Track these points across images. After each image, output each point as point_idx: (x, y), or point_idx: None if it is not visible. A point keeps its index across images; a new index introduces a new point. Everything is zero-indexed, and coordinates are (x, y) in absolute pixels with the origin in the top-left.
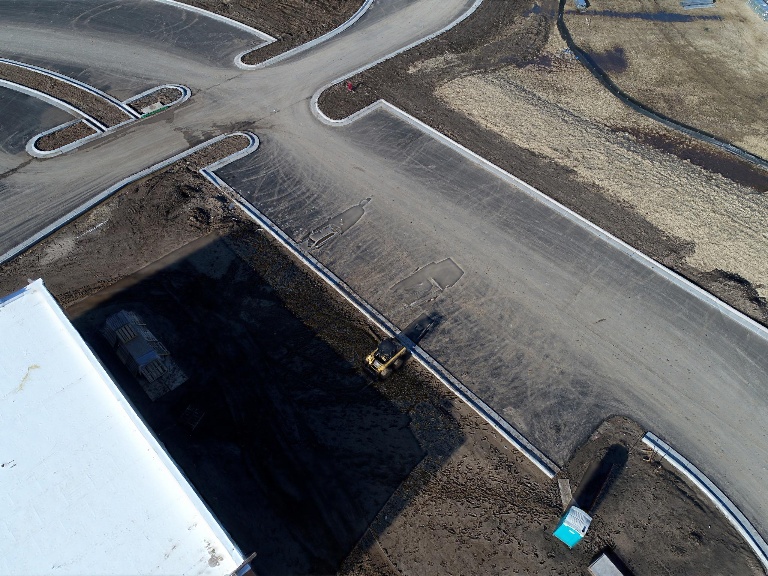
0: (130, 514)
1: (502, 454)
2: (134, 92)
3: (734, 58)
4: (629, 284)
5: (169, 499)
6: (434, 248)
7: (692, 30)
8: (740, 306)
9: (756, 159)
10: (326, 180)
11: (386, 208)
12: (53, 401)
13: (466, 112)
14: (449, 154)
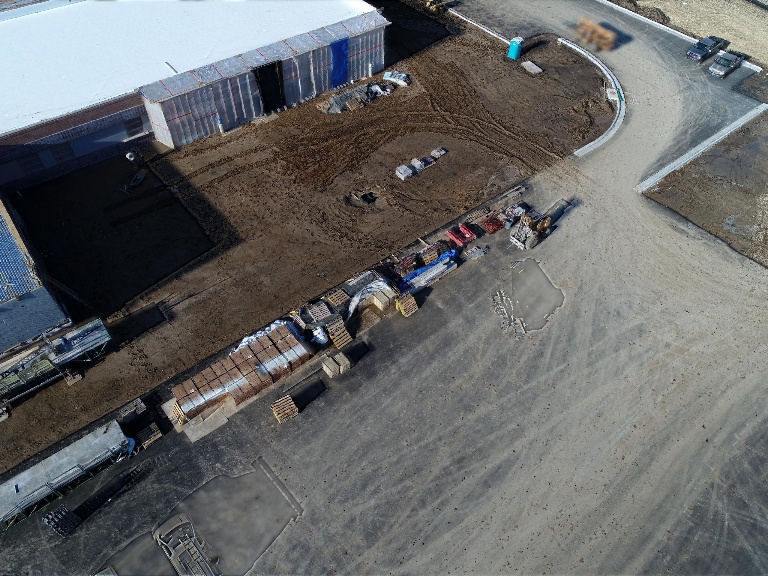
0: (331, 5)
1: (488, 38)
2: None
3: None
4: None
5: (346, 3)
6: None
7: None
8: (624, 6)
9: None
10: None
11: None
12: None
13: None
14: None
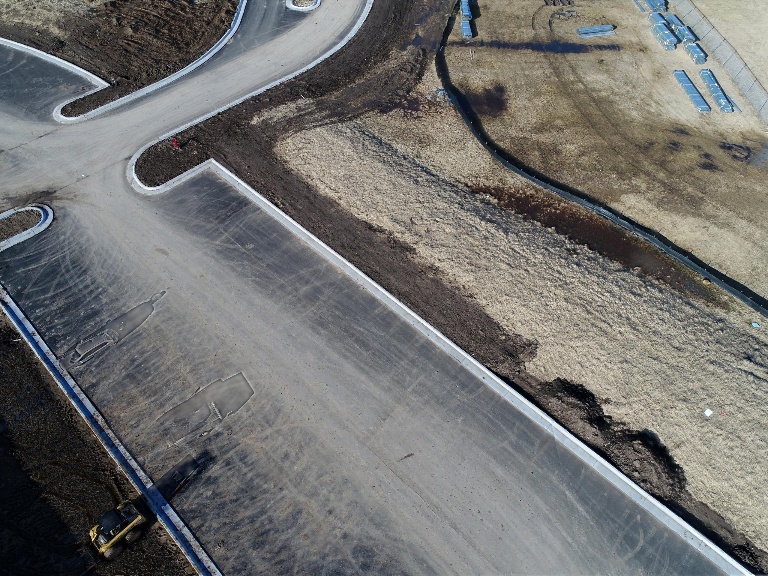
0: None
1: None
2: None
3: (626, 96)
4: (451, 402)
5: None
6: (225, 359)
7: (585, 63)
8: (578, 430)
9: (629, 225)
10: (119, 268)
11: (181, 304)
12: None
13: (304, 174)
14: (274, 229)
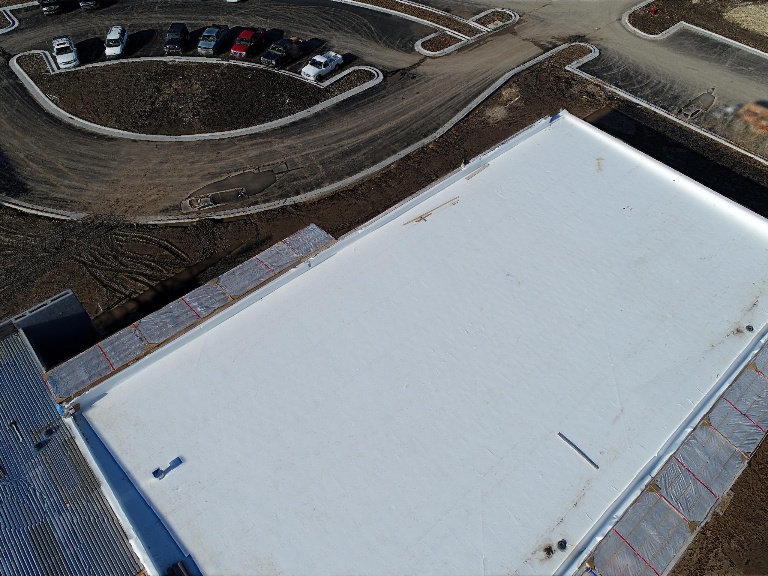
0: (730, 236)
1: None
2: (472, 13)
3: None
4: None
5: (749, 230)
6: None
7: None
8: None
9: None
10: (670, 76)
11: (731, 95)
12: (629, 177)
13: (760, 31)
14: (760, 60)
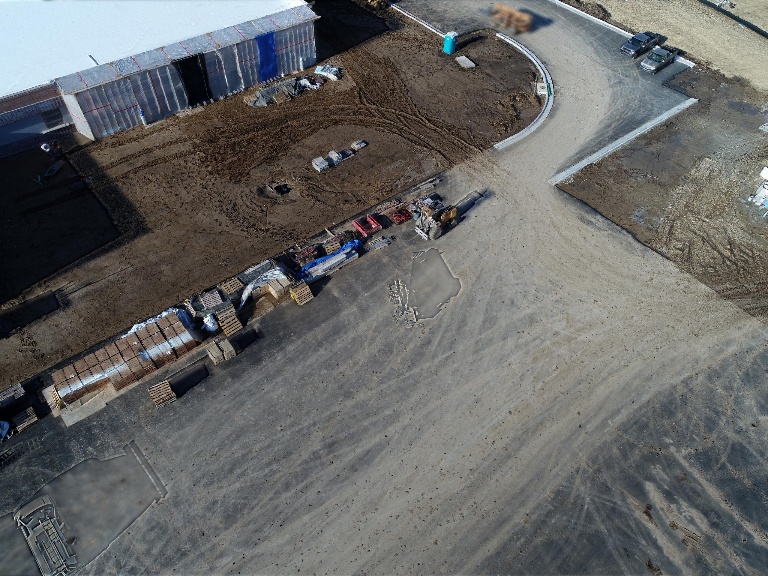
0: None
1: (427, 33)
2: None
3: None
4: None
5: None
6: None
7: None
8: (567, 2)
9: None
10: None
11: None
12: None
13: None
14: None
